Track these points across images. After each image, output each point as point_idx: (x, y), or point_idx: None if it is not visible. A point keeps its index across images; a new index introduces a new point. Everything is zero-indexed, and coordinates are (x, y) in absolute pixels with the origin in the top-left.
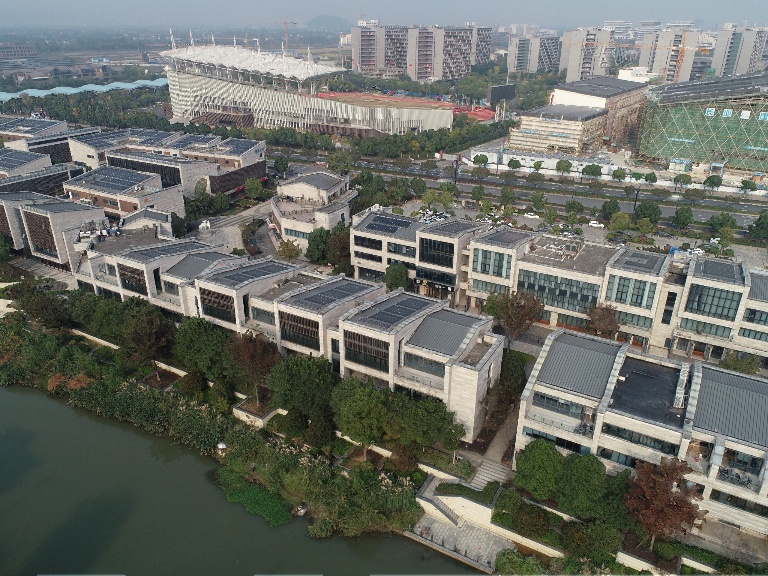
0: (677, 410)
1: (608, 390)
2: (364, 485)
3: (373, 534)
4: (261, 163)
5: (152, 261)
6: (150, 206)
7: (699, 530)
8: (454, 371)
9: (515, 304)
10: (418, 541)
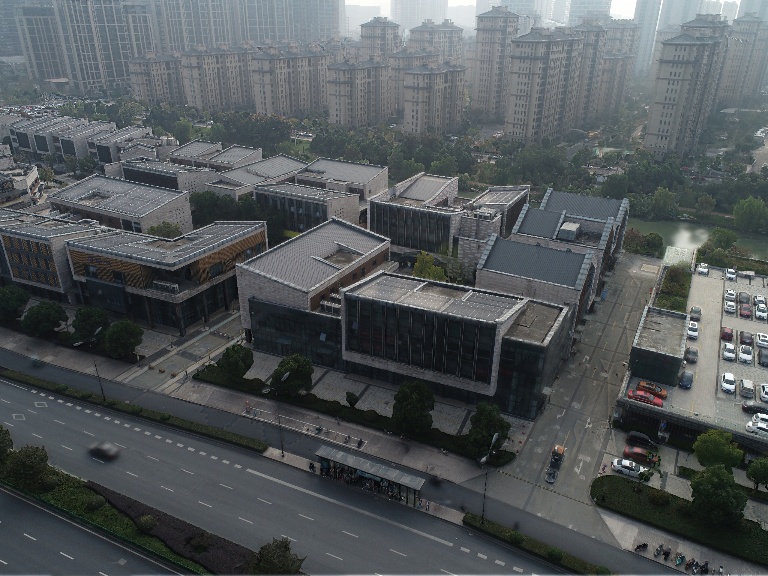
0: None
1: None
2: None
3: None
4: None
5: None
6: None
7: None
8: None
9: None
10: None
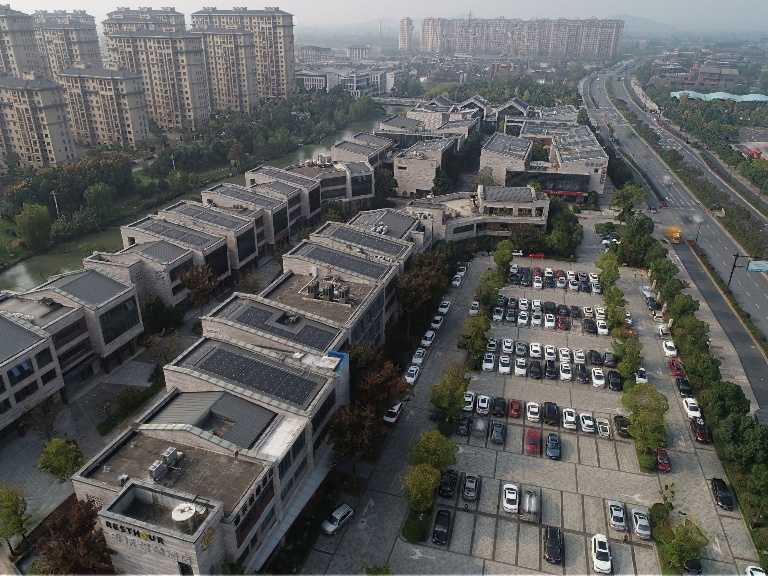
0: None
1: None
2: None
3: None
4: (581, 176)
5: (250, 173)
6: (404, 167)
7: None
8: None
9: None
10: None
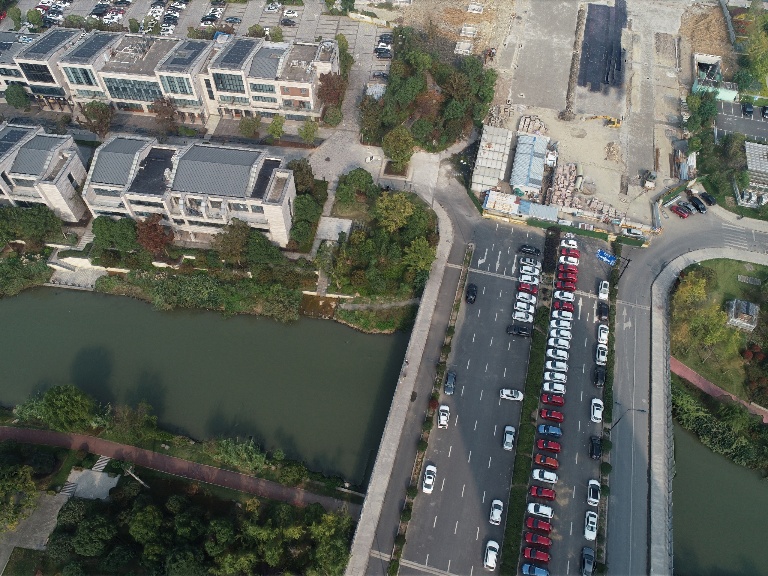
0: (168, 182)
1: (129, 179)
2: (11, 266)
3: (26, 290)
4: None
5: None
6: None
7: (196, 239)
8: (42, 187)
9: (114, 102)
10: (53, 286)
